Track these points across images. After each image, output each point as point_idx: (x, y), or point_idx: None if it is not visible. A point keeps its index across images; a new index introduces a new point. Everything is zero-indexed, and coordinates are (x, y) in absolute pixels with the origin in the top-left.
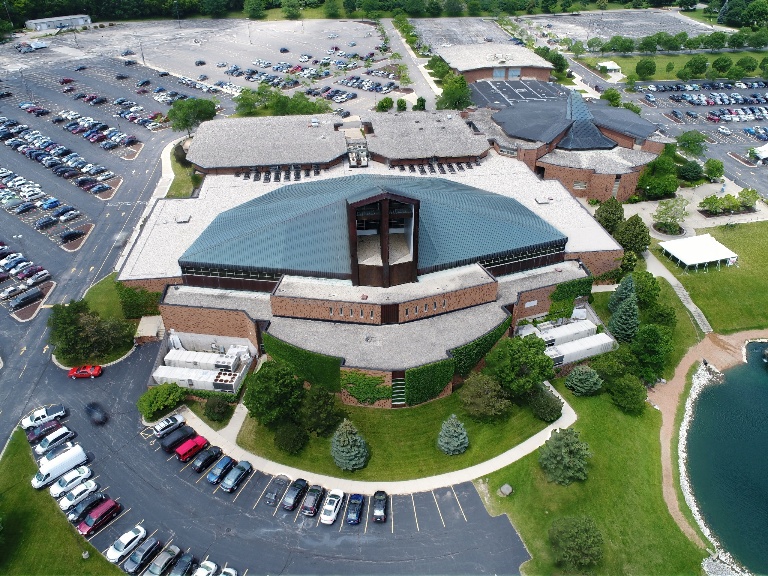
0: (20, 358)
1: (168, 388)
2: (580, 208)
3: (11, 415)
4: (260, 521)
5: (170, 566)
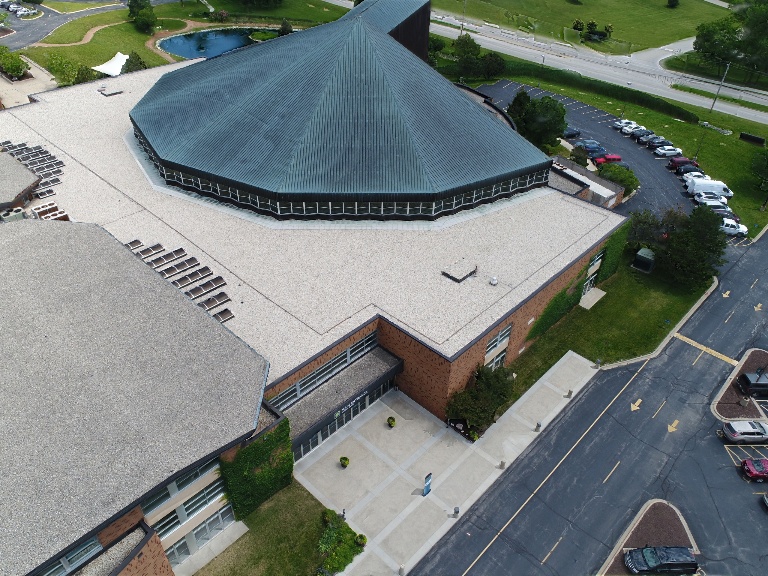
0: (761, 299)
1: (612, 164)
2: (119, 77)
3: (761, 252)
4: (587, 134)
5: (647, 135)
